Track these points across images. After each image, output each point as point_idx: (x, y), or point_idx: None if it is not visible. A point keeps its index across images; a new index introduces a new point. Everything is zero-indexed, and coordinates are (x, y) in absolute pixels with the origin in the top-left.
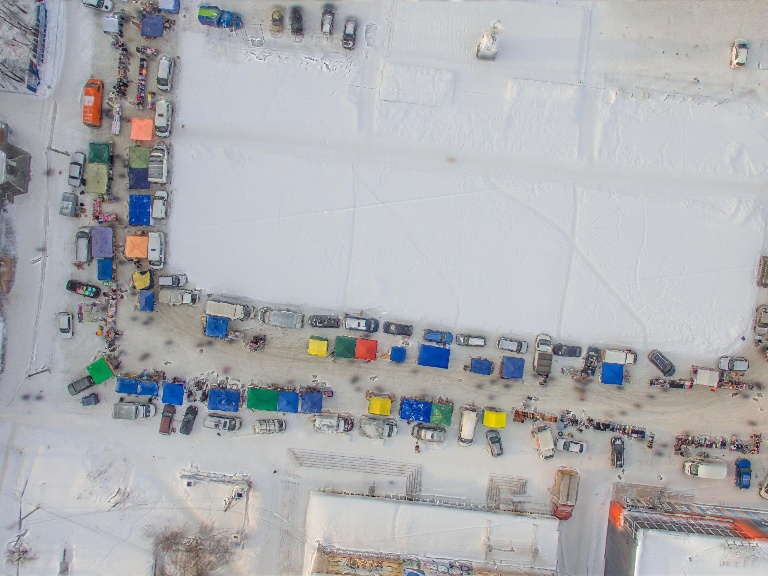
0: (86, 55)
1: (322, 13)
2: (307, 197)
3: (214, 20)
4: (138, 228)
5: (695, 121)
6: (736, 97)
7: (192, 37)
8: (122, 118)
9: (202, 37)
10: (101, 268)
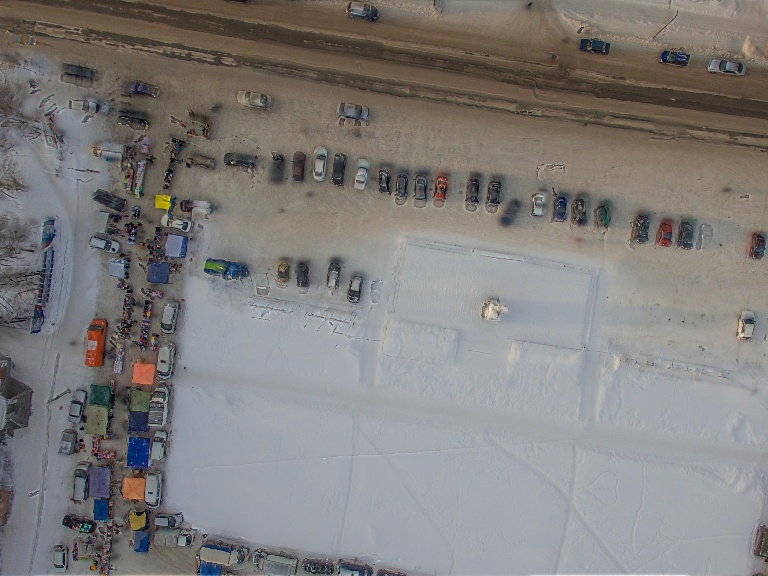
0: (91, 294)
1: (328, 267)
2: (306, 443)
3: (220, 274)
4: (136, 465)
5: (698, 390)
6: (741, 367)
7: (198, 283)
8: (125, 357)
9: (208, 283)
10: (97, 509)
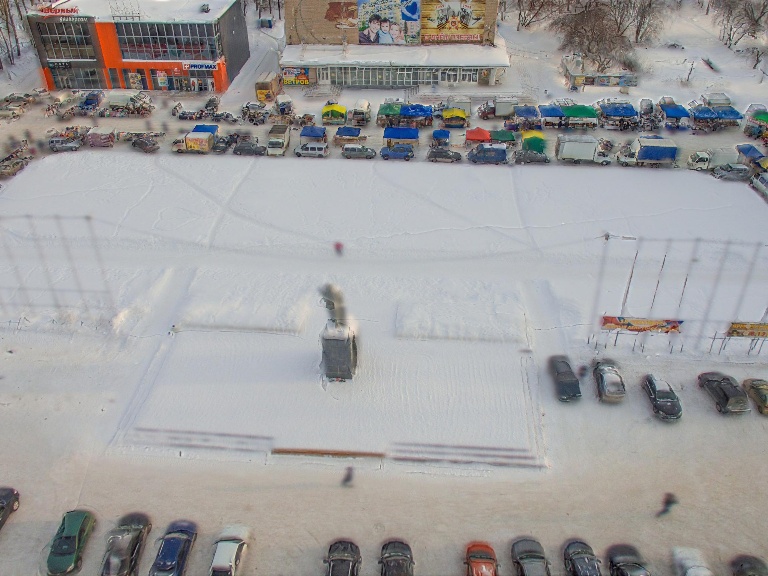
0: None
1: None
2: None
3: None
4: None
5: None
6: None
7: None
8: None
9: None
10: None
